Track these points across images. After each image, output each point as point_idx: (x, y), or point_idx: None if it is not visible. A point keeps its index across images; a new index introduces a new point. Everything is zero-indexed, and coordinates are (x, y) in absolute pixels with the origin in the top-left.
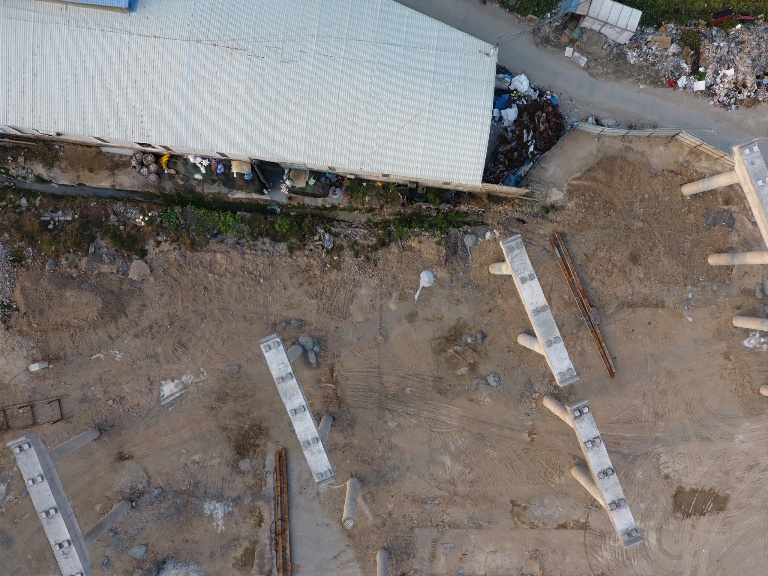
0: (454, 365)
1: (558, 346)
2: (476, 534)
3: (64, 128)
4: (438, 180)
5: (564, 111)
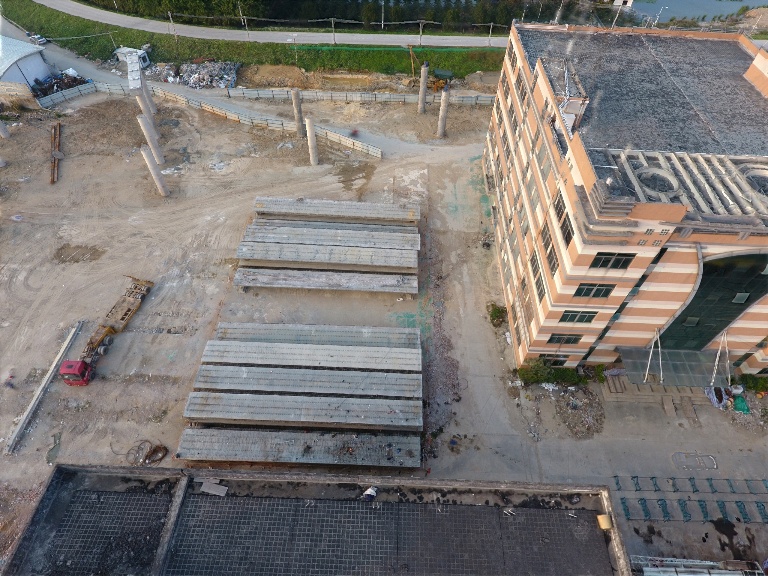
0: None
1: None
2: None
3: None
4: None
5: None
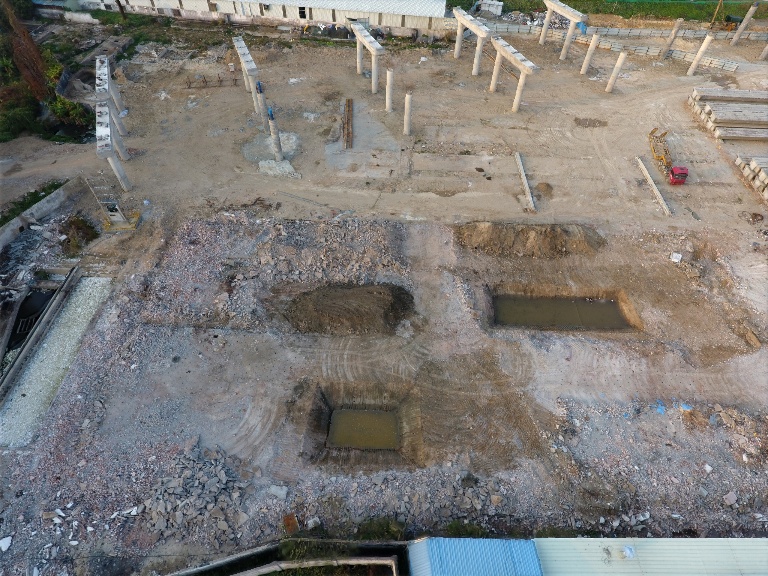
0: None
1: (483, 26)
2: None
3: (273, 3)
4: (426, 16)
5: None
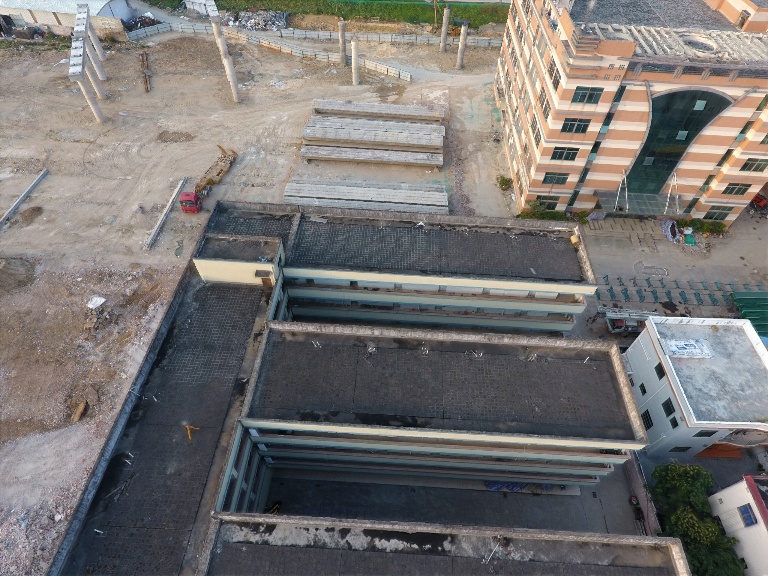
0: (57, 85)
1: None
2: (15, 141)
3: None
4: None
5: None
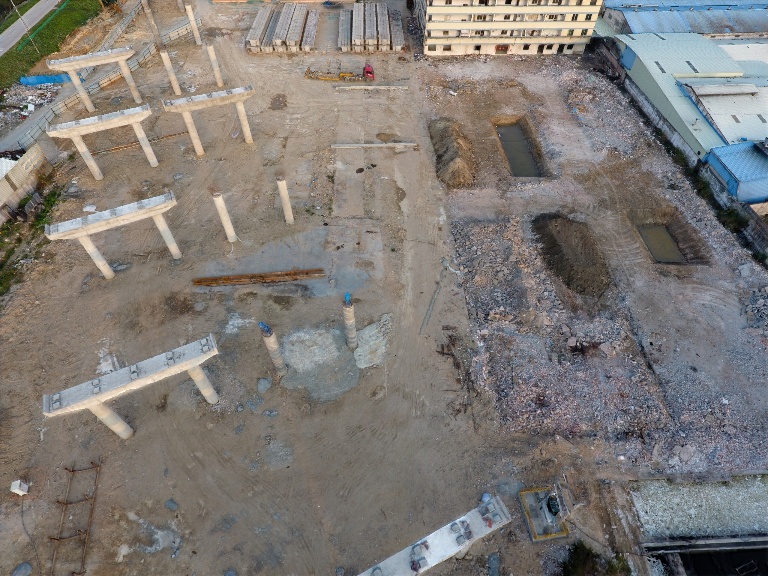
0: None
1: (126, 111)
2: None
3: None
4: (1, 179)
5: None
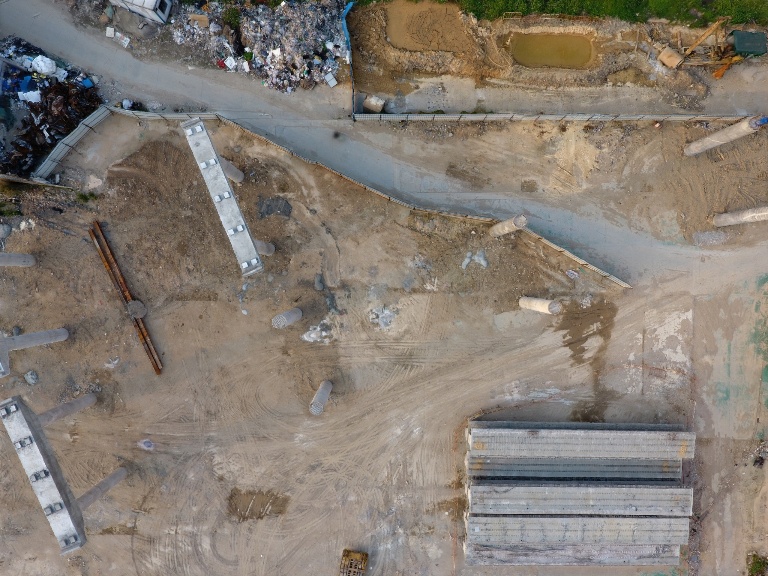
0: None
1: None
2: (13, 540)
3: None
4: None
5: (105, 94)
